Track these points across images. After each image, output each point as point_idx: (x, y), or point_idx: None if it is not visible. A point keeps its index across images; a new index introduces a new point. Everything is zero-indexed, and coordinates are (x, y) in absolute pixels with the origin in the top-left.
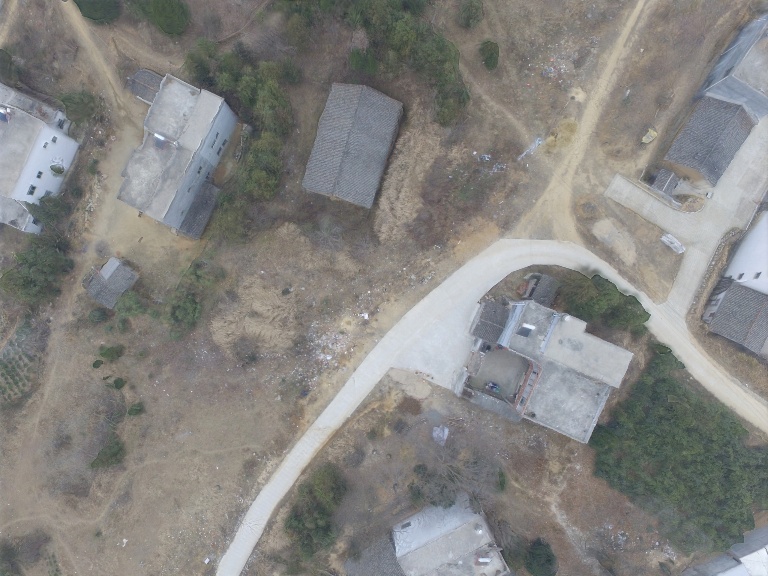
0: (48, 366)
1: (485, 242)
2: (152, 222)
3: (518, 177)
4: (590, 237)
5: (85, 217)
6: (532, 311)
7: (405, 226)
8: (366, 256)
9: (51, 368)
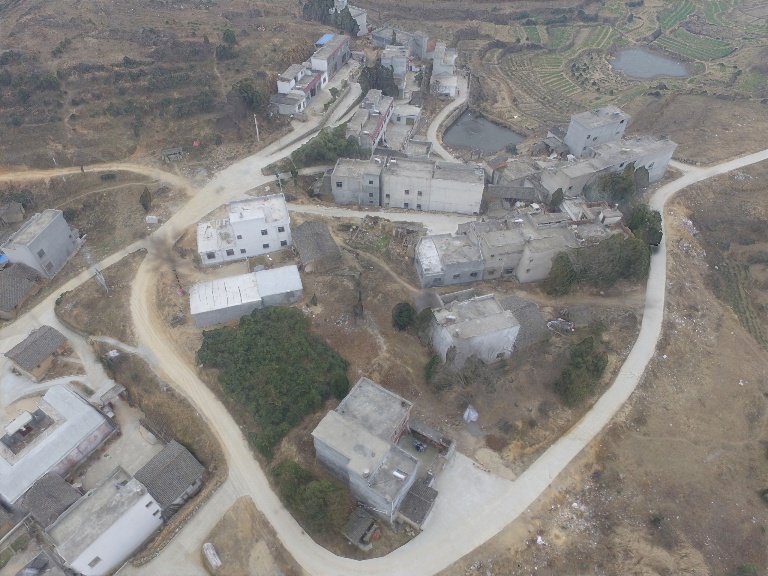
0: None
1: None
2: None
3: None
4: None
5: None
6: (389, 493)
7: None
8: None
9: None
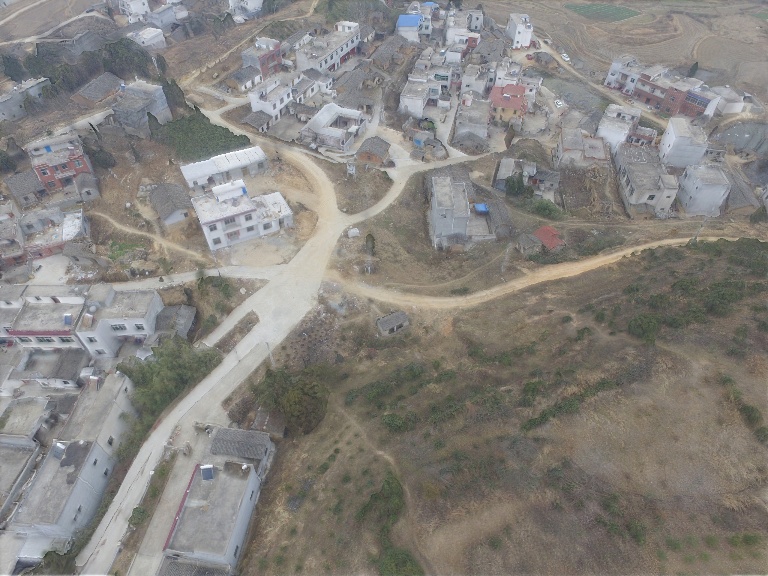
0: None
1: None
2: None
3: None
4: None
5: None
6: None
7: None
8: None
9: None
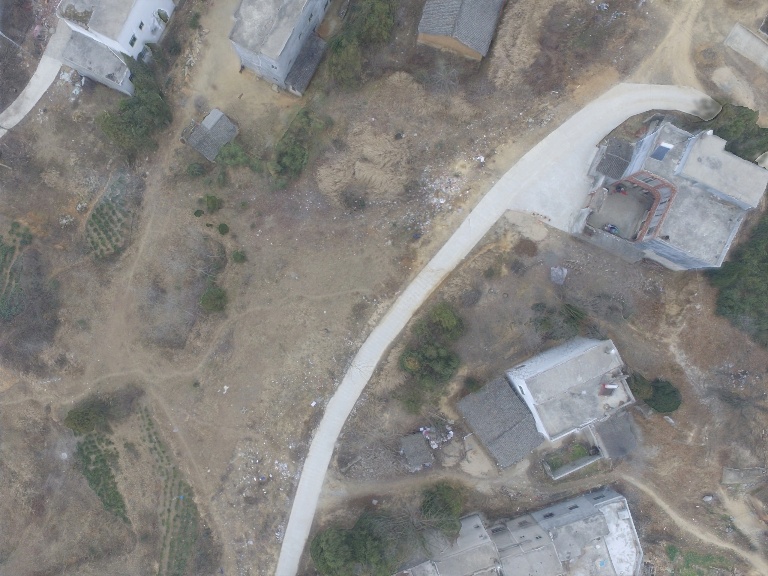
0: (144, 220)
1: (605, 85)
2: (253, 79)
3: (638, 24)
4: (710, 83)
5: (185, 72)
6: (667, 135)
7: (522, 72)
8: (481, 102)
9: (147, 222)
